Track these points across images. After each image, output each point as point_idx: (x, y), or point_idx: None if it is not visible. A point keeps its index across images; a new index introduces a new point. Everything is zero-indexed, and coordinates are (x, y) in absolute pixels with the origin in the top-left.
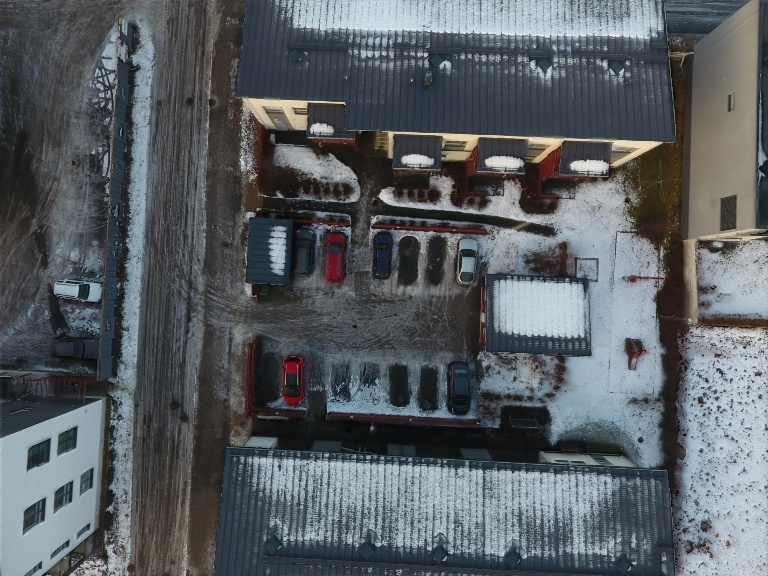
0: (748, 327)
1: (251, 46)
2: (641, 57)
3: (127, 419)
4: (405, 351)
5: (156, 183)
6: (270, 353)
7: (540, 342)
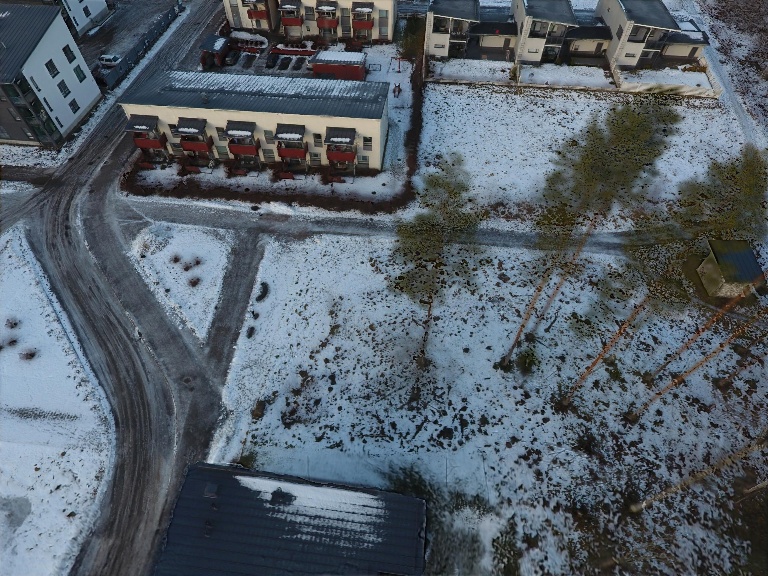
0: (457, 84)
1: None
2: None
3: (109, 104)
4: None
5: (170, 41)
6: None
7: None
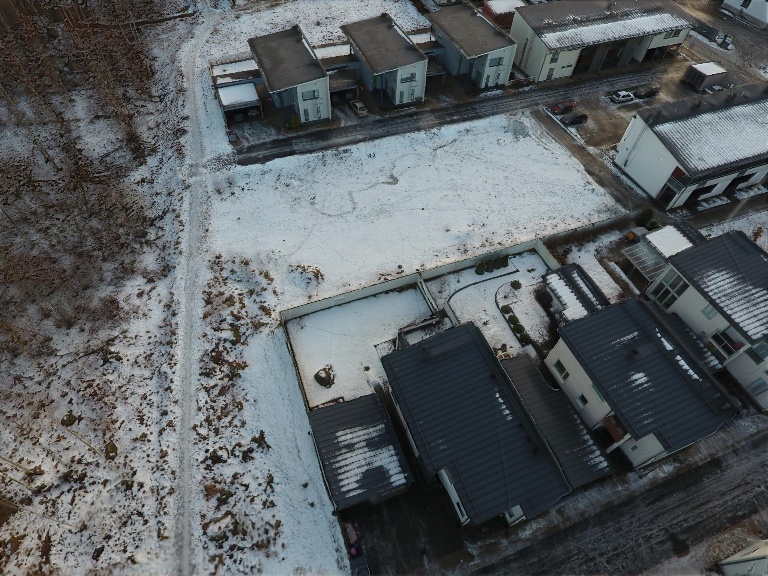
0: None
1: (675, 5)
2: None
3: None
4: None
5: None
6: None
7: None
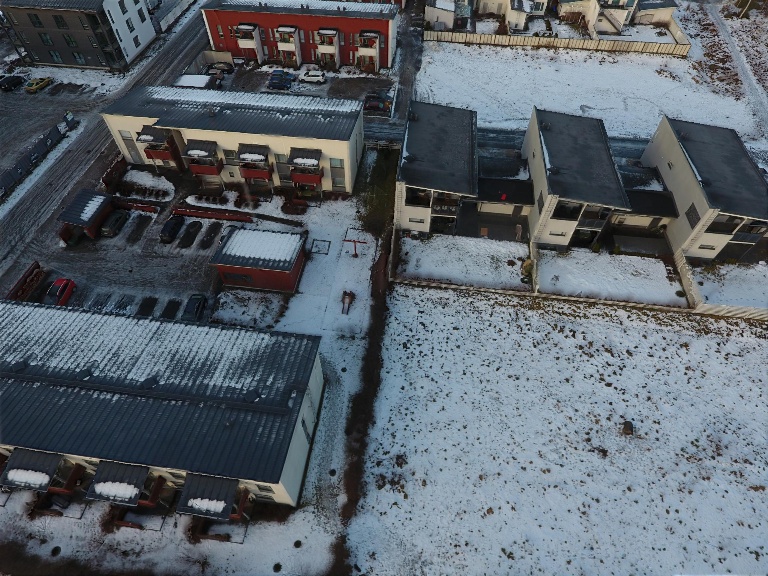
0: (441, 289)
1: None
2: (341, 115)
3: None
4: (162, 289)
5: (39, 185)
6: (52, 282)
7: (253, 261)
